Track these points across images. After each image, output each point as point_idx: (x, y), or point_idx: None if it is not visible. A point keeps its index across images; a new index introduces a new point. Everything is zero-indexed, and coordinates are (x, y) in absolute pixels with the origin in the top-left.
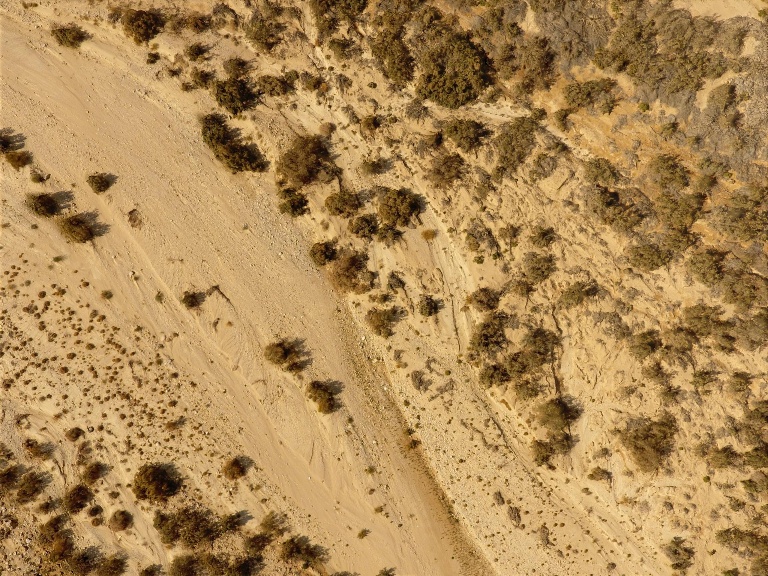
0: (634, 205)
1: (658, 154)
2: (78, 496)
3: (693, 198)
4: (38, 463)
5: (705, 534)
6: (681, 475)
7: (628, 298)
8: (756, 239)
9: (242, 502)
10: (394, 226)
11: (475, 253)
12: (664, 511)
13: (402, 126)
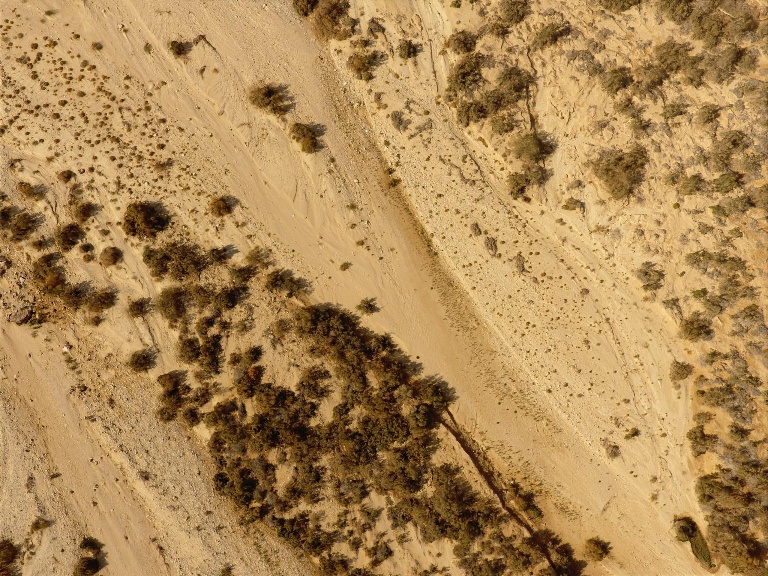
0: None
1: None
2: (70, 232)
3: None
4: (31, 205)
5: (675, 258)
6: (652, 203)
7: (600, 37)
8: None
9: (228, 237)
10: None
11: None
12: (635, 237)
13: None
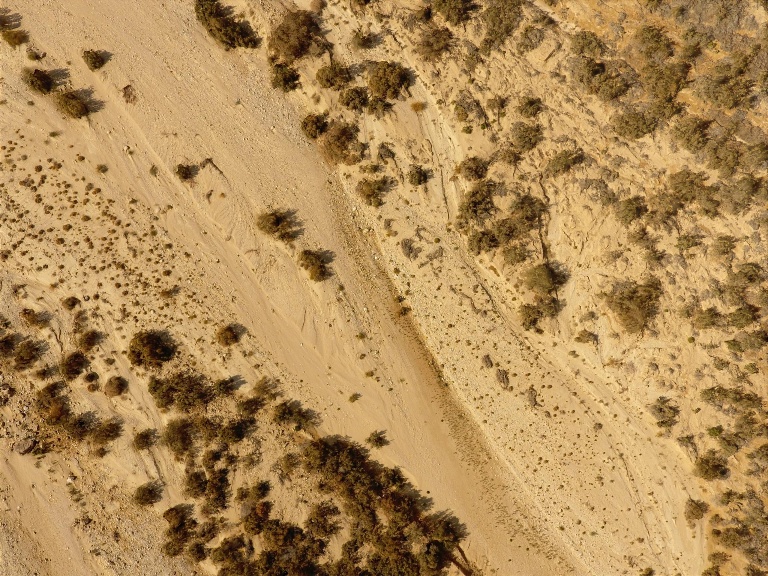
0: (620, 75)
1: (643, 26)
2: (74, 362)
3: (678, 67)
4: (35, 332)
5: (690, 393)
6: (666, 336)
7: (614, 165)
8: (740, 107)
9: (235, 367)
10: (384, 99)
11: (464, 123)
12: (649, 371)
13: (392, 1)
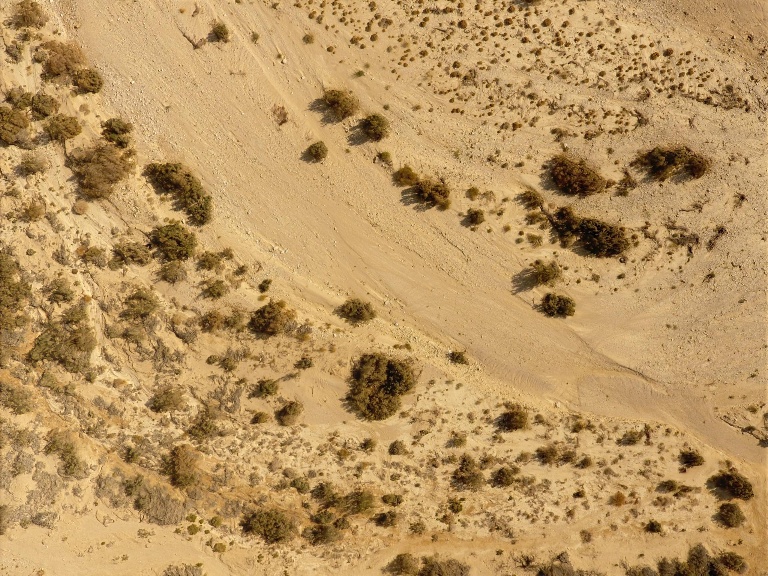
0: None
1: None
2: None
3: None
4: None
5: None
6: None
7: None
8: None
9: None
10: (14, 108)
11: None
12: None
13: (2, 210)
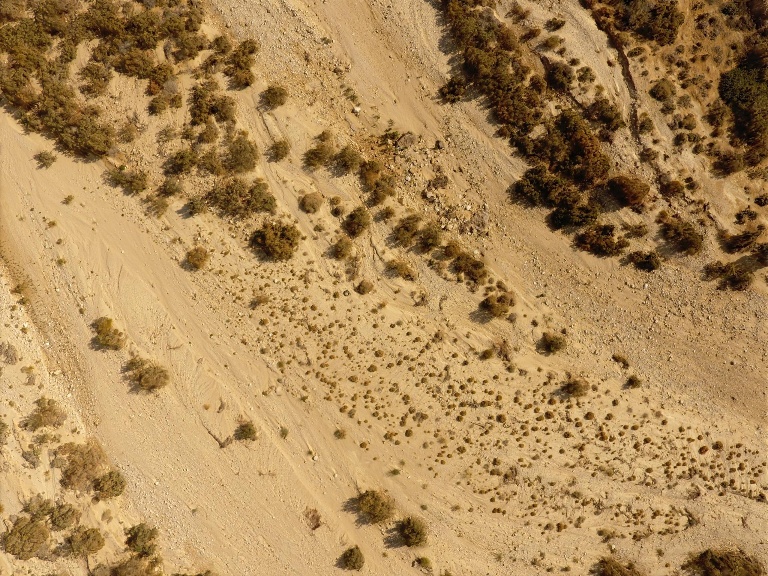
0: None
1: None
2: (354, 227)
3: None
4: (401, 257)
5: None
6: None
7: None
8: None
9: (188, 227)
10: (33, 518)
11: None
12: None
13: None
